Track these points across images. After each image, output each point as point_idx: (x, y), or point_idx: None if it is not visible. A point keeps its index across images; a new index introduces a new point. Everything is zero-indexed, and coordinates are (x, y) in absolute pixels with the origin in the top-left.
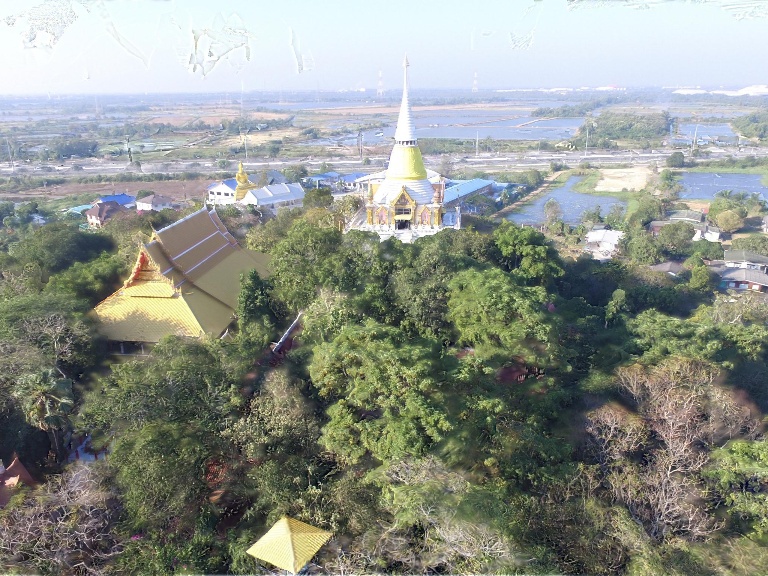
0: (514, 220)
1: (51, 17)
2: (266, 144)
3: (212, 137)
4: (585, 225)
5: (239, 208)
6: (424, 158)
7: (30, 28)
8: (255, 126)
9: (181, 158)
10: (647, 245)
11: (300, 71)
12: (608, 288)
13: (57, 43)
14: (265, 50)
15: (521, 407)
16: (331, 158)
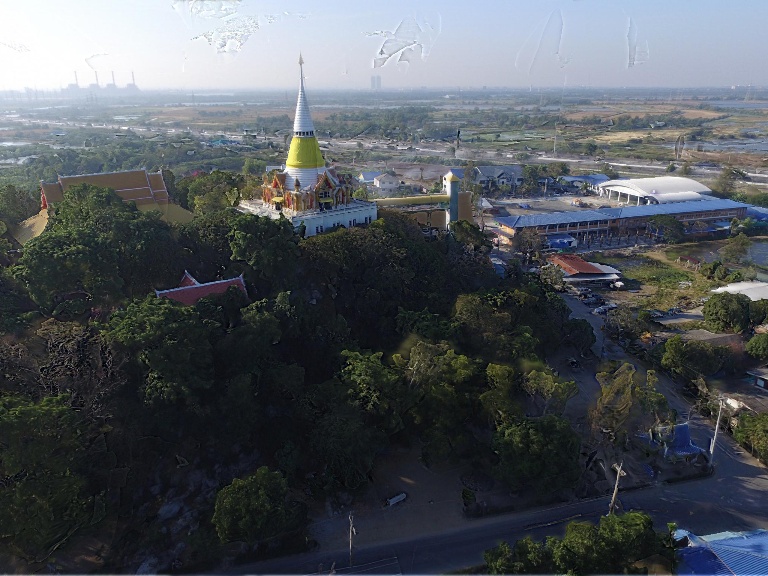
0: (704, 253)
1: (241, 29)
2: (621, 142)
3: (587, 132)
4: (741, 271)
5: (235, 178)
6: (701, 169)
7: (223, 38)
8: (648, 124)
9: (513, 149)
10: (715, 304)
11: (632, 65)
12: (449, 314)
13: (242, 48)
14: (597, 43)
15: (1, 324)
16: (652, 162)
